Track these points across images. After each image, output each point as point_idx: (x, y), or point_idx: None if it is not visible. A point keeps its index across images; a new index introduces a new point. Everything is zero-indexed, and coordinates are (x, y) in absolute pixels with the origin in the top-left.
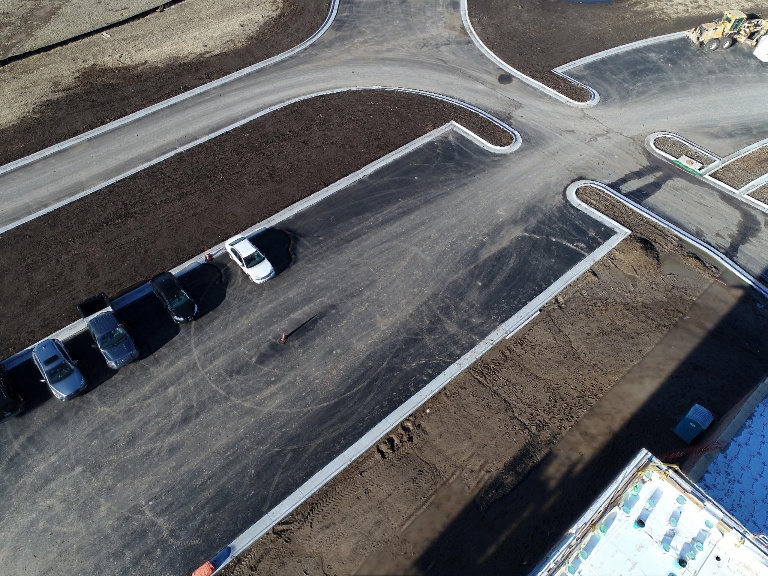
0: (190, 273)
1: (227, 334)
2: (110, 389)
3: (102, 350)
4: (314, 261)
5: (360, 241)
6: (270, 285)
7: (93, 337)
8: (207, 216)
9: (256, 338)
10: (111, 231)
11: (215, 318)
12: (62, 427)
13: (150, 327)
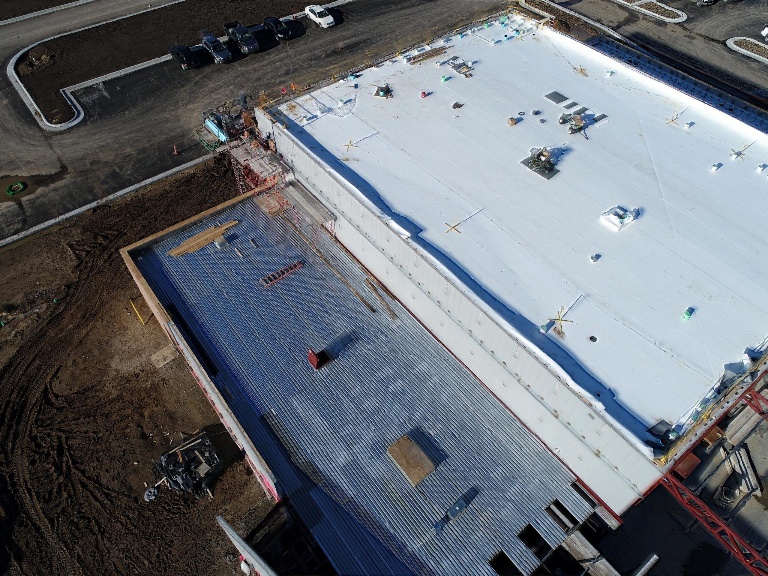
0: (284, 23)
1: (308, 46)
2: (244, 62)
3: (240, 42)
4: (358, 22)
5: (386, 15)
6: (332, 30)
7: (235, 37)
8: (293, 1)
9: (324, 48)
10: (235, 5)
11: (300, 40)
12: (220, 73)
13: (263, 42)
